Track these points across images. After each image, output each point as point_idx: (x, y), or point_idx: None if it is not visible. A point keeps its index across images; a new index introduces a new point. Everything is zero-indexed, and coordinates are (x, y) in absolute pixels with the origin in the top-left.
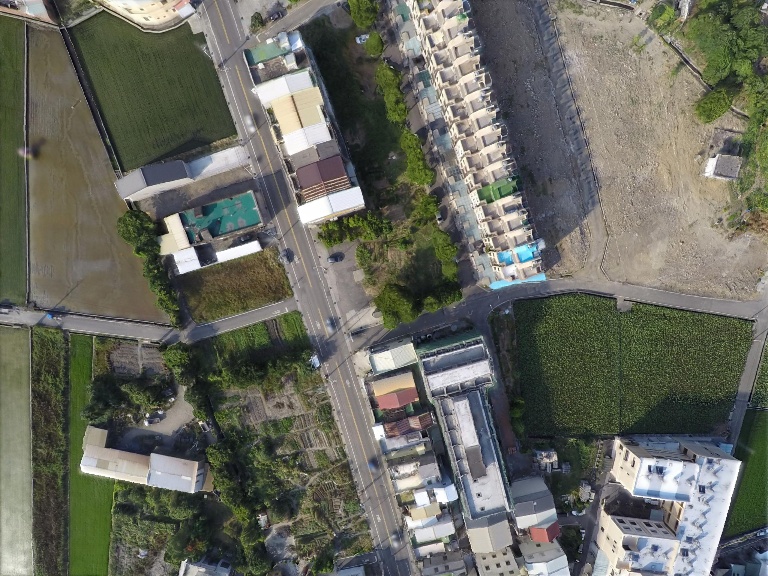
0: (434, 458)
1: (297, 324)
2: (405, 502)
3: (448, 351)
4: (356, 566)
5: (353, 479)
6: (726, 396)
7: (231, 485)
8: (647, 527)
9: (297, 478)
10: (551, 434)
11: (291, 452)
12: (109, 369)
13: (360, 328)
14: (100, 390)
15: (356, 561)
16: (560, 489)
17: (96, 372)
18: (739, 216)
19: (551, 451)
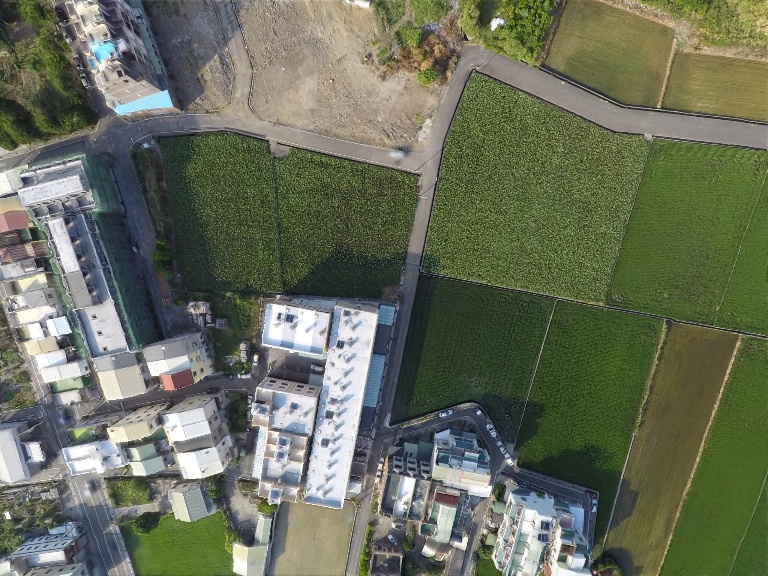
0: (47, 288)
1: None
2: (28, 338)
3: (46, 167)
4: (20, 420)
5: (9, 325)
6: (393, 257)
7: None
8: (295, 387)
9: None
10: (211, 288)
11: None
12: None
13: None
14: None
15: (21, 415)
16: (220, 348)
17: None
18: (389, 52)
19: (199, 301)
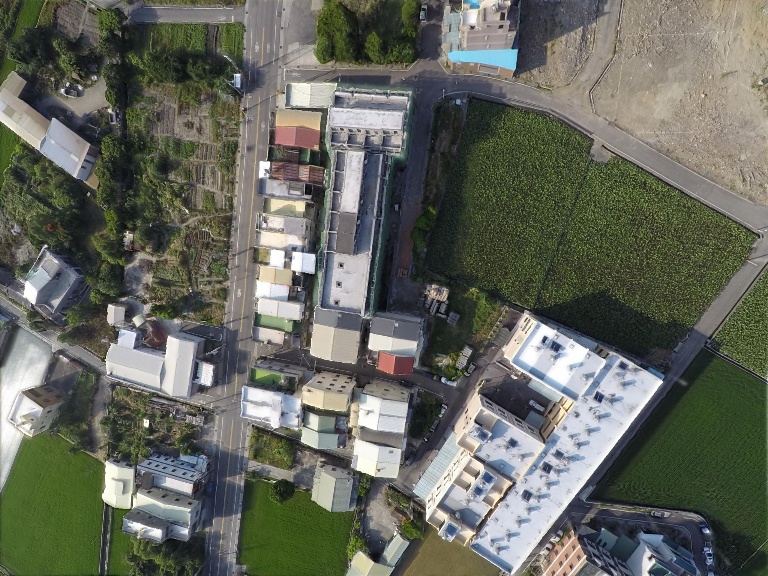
0: None
1: (237, 38)
2: (261, 261)
3: (367, 93)
4: (199, 335)
5: (230, 238)
6: (682, 318)
7: (111, 184)
8: (516, 421)
9: (177, 212)
10: (454, 276)
11: (182, 181)
12: (52, 22)
13: (297, 67)
14: (34, 35)
15: (201, 330)
16: (438, 343)
17: (40, 22)
18: None
19: (443, 287)
